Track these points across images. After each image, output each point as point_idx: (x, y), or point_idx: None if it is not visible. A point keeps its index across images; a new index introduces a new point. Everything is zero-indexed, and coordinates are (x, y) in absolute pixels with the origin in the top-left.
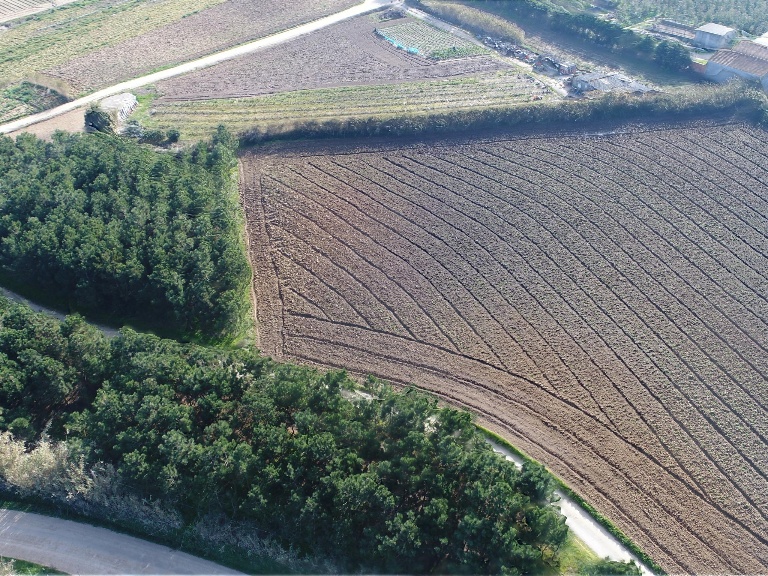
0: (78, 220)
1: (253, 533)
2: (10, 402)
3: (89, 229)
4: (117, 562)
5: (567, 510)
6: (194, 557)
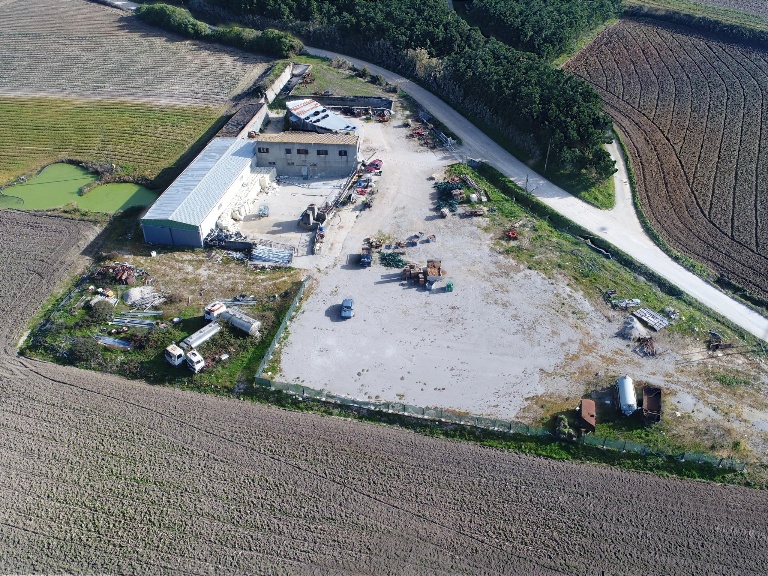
0: (509, 2)
1: (483, 103)
2: (434, 44)
3: (510, 4)
4: (433, 104)
5: (618, 161)
6: (459, 114)
